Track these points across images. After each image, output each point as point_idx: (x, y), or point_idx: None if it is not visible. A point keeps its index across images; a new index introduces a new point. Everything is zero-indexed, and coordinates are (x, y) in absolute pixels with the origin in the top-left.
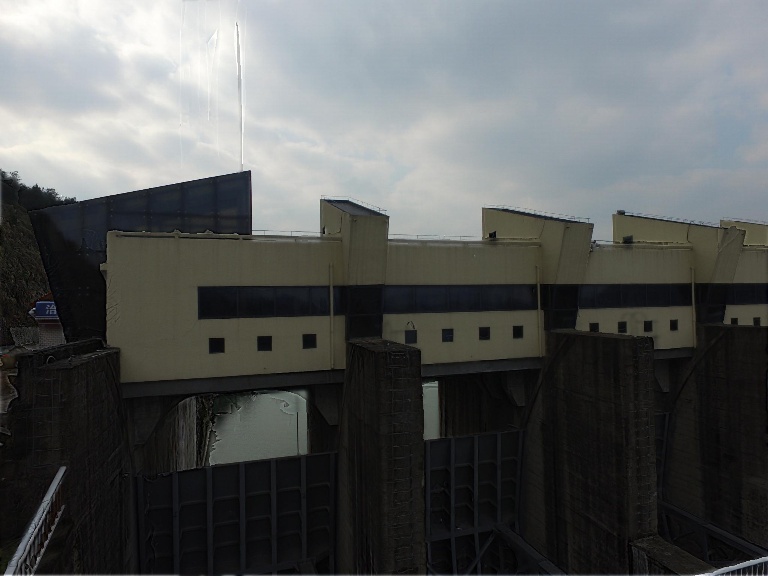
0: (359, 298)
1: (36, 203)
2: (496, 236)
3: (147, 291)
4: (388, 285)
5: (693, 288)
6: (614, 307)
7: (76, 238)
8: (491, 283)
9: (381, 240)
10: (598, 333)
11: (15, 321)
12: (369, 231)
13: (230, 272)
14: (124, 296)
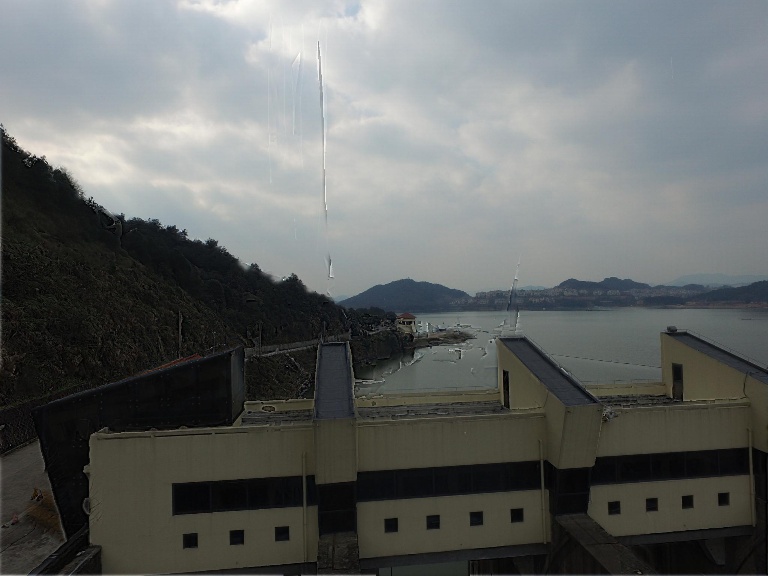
0: (330, 493)
1: (136, 244)
2: (508, 377)
3: (126, 490)
4: (366, 471)
5: (751, 454)
6: (641, 481)
7: (74, 426)
8: (484, 462)
9: (348, 440)
10: (604, 541)
11: (101, 380)
12: (334, 433)
13: (203, 467)
14: (105, 496)
